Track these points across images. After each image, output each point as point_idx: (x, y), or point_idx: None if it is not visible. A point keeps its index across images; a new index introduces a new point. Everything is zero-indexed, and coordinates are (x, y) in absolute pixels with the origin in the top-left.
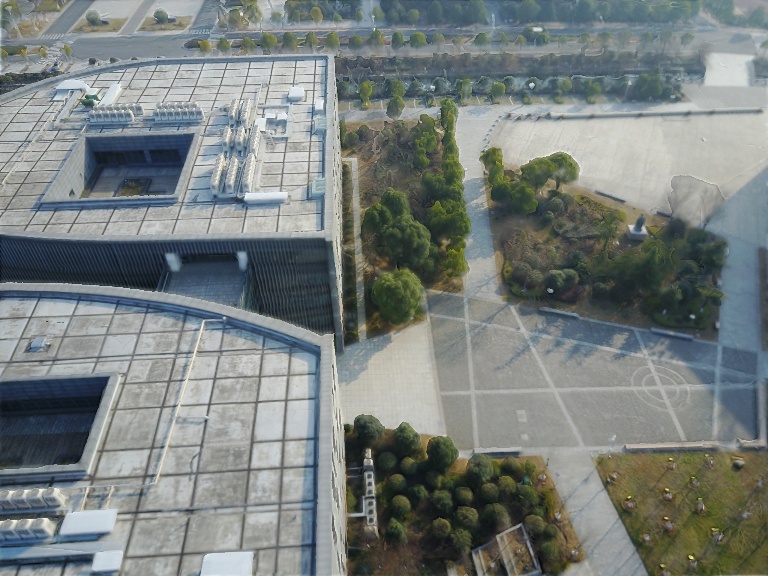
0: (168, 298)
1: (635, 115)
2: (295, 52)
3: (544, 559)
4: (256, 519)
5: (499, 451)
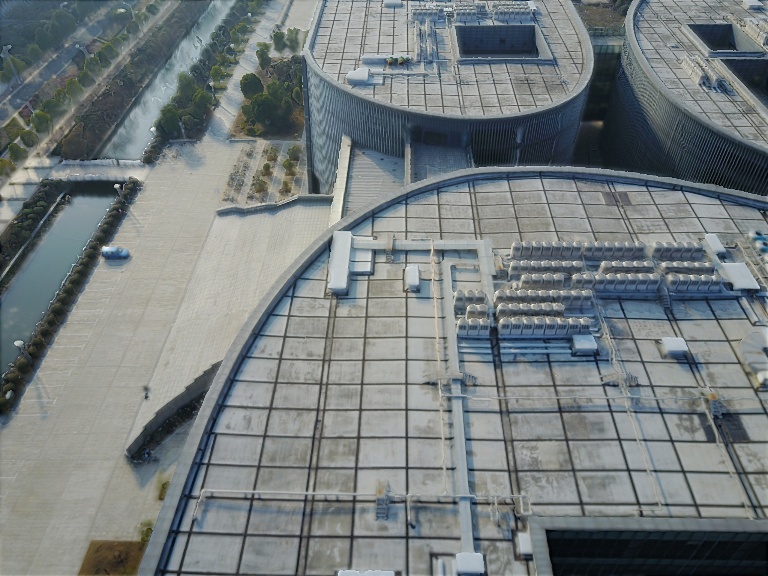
0: None
1: (291, 4)
2: (59, 120)
3: None
4: None
5: None
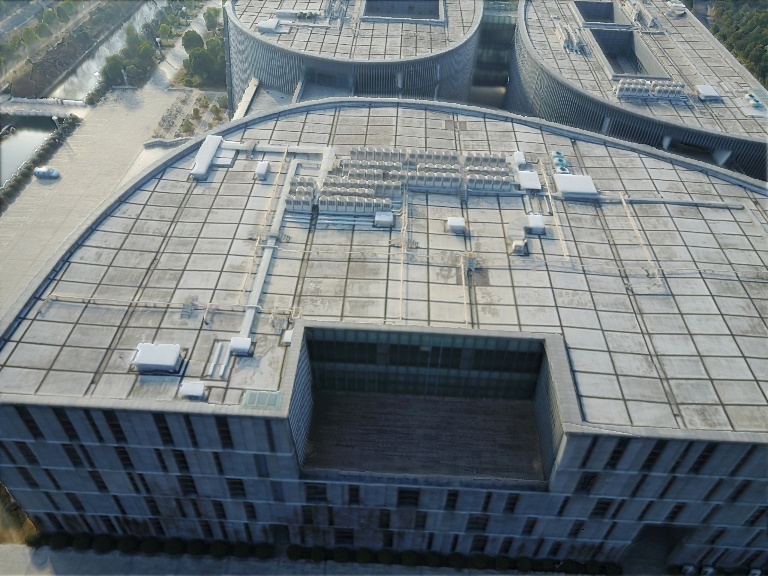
0: None
1: None
2: (13, 64)
3: None
4: None
5: None
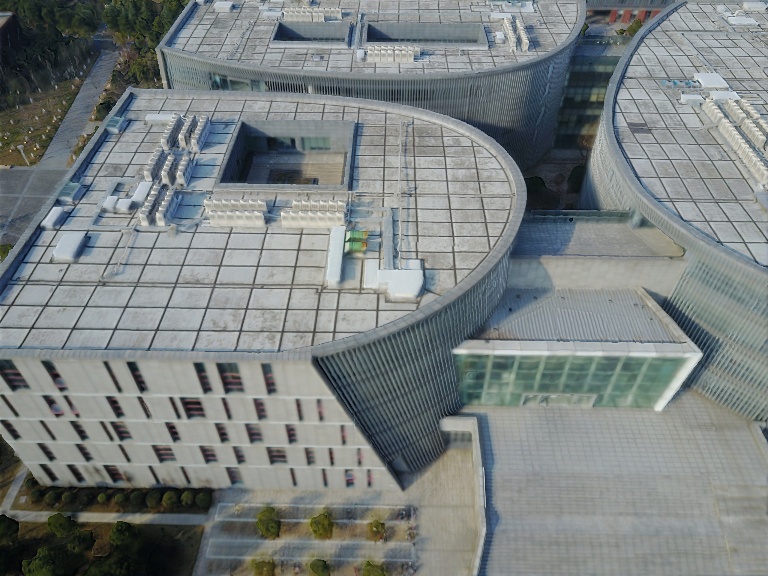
0: (245, 64)
1: None
2: None
3: None
4: None
5: None
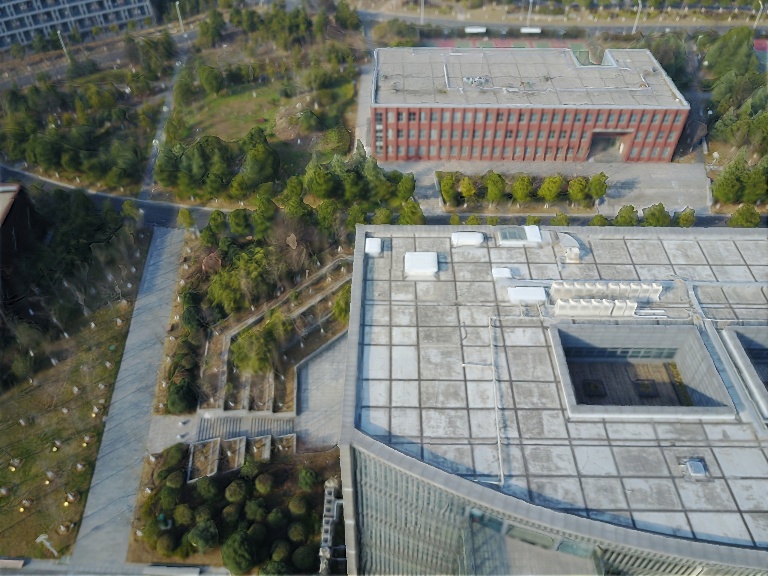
0: (564, 519)
1: None
2: None
3: (183, 451)
4: (407, 296)
5: (171, 568)
